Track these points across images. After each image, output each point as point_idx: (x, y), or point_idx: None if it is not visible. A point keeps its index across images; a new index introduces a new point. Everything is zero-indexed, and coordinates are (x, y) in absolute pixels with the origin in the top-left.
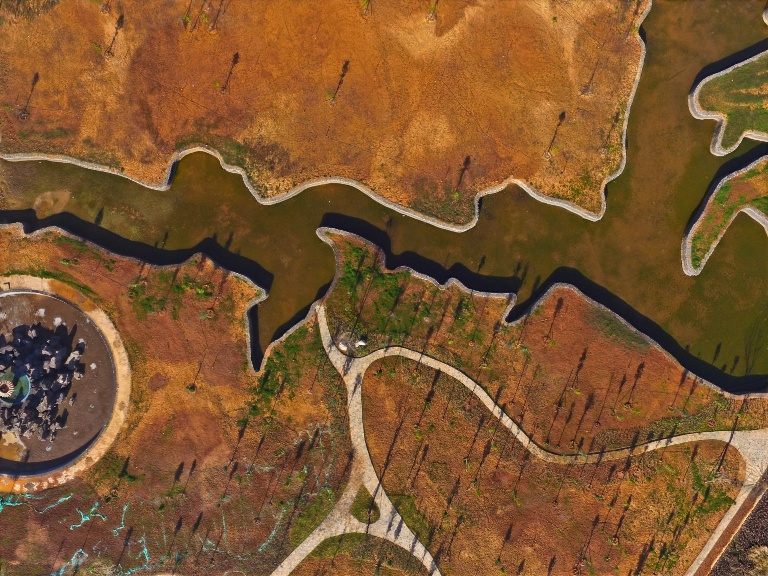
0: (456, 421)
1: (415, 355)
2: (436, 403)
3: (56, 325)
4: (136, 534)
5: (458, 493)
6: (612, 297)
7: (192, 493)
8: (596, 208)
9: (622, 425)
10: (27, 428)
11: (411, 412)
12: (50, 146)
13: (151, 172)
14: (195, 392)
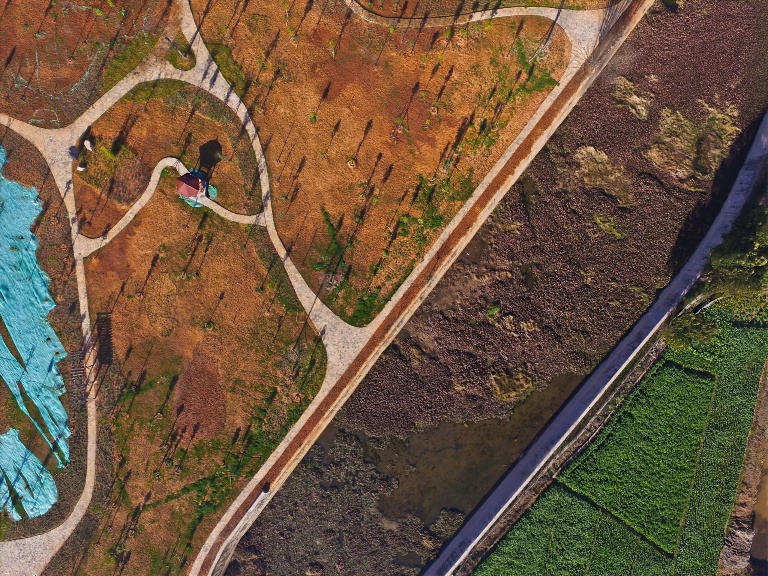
0: None
1: None
2: None
3: None
4: None
5: (277, 47)
6: None
7: (6, 27)
8: None
9: None
10: None
11: None
12: None
13: None
14: None
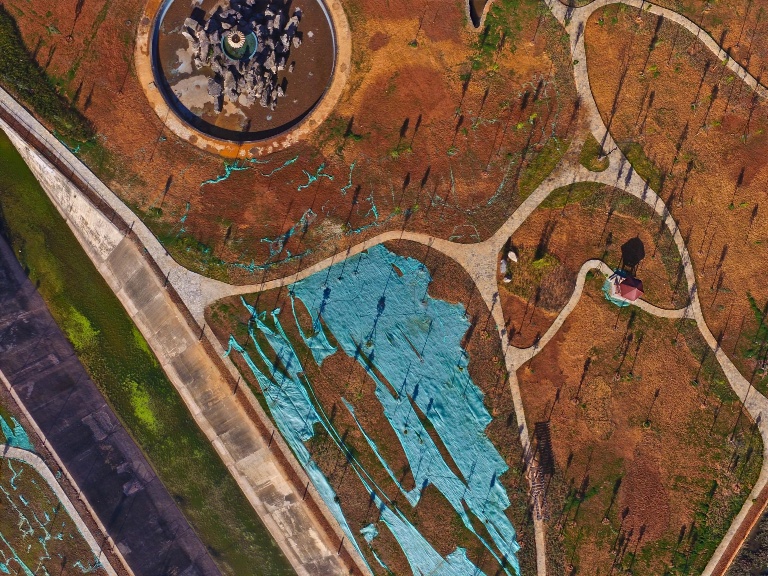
0: (681, 67)
1: (637, 2)
2: (660, 49)
3: None
4: (364, 192)
5: (687, 138)
6: None
7: (419, 148)
8: None
9: None
10: (257, 82)
11: (635, 59)
12: None
13: None
14: (417, 48)
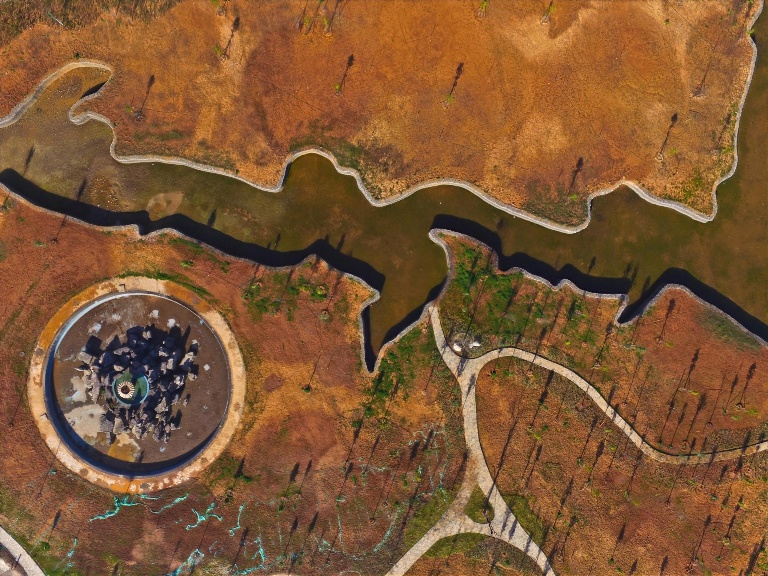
0: (569, 421)
1: (529, 356)
2: (549, 404)
3: (170, 326)
4: (252, 534)
5: (572, 493)
6: (721, 298)
7: (308, 493)
8: (708, 209)
9: (734, 425)
10: (146, 429)
11: (525, 413)
12: (165, 148)
13: (266, 174)
14: (310, 393)
